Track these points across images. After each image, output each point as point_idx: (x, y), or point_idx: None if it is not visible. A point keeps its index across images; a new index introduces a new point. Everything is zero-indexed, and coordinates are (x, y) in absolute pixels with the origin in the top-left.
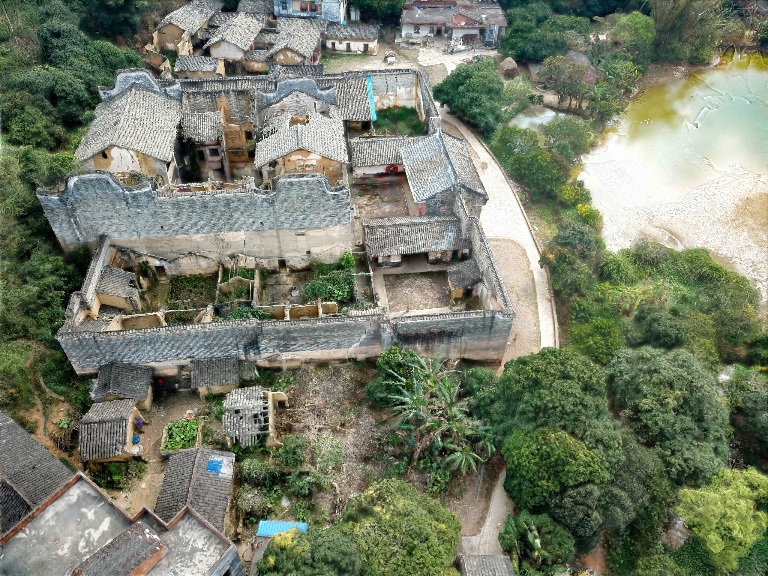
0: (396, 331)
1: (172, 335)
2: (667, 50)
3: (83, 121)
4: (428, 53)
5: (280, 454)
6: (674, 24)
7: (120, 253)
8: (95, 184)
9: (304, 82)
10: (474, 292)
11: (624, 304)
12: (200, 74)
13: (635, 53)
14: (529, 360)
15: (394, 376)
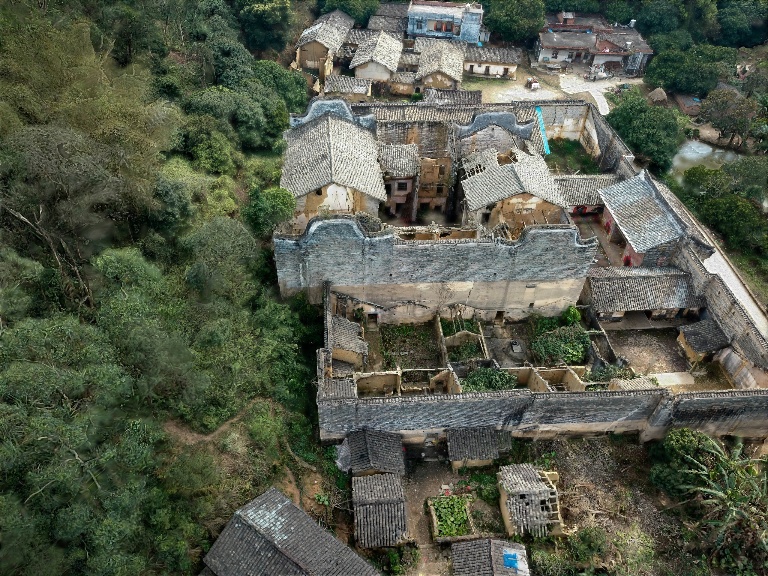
0: (676, 407)
1: (438, 404)
2: None
3: (276, 150)
4: (569, 79)
5: (566, 545)
6: None
7: (340, 300)
8: (338, 229)
9: (503, 116)
10: (716, 356)
11: None
12: (350, 96)
13: None
14: None
15: (694, 463)
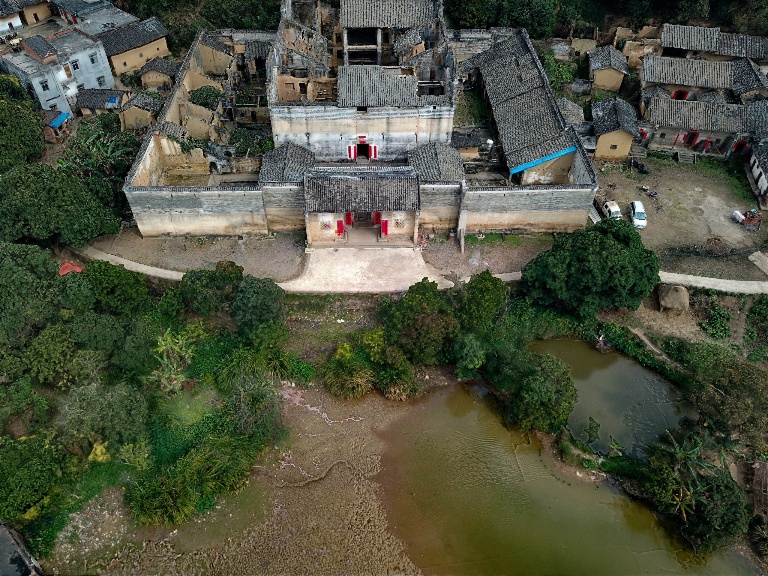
0: None
1: None
2: None
3: None
4: None
5: None
6: None
7: None
8: None
9: None
10: None
11: None
12: None
13: None
14: None
15: None
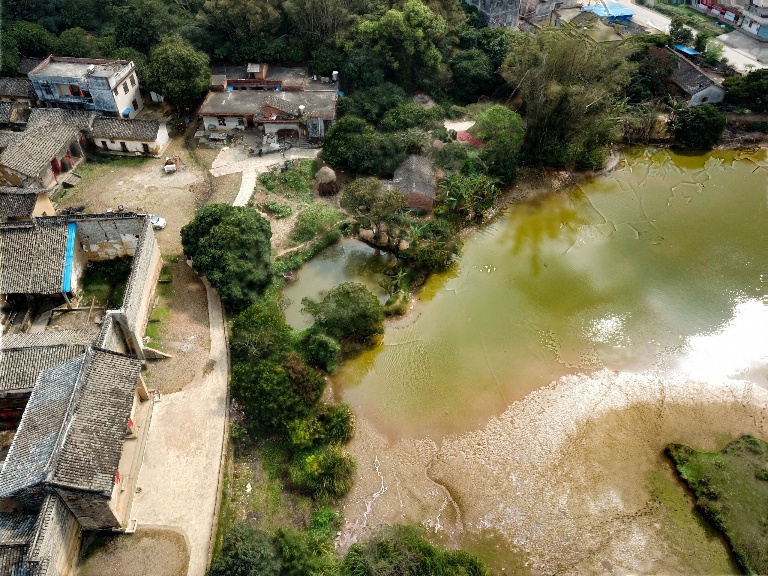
0: None
1: None
2: (544, 151)
3: None
4: (229, 154)
5: None
6: (552, 119)
7: None
8: None
9: None
10: None
11: None
12: None
13: (491, 163)
14: None
15: None
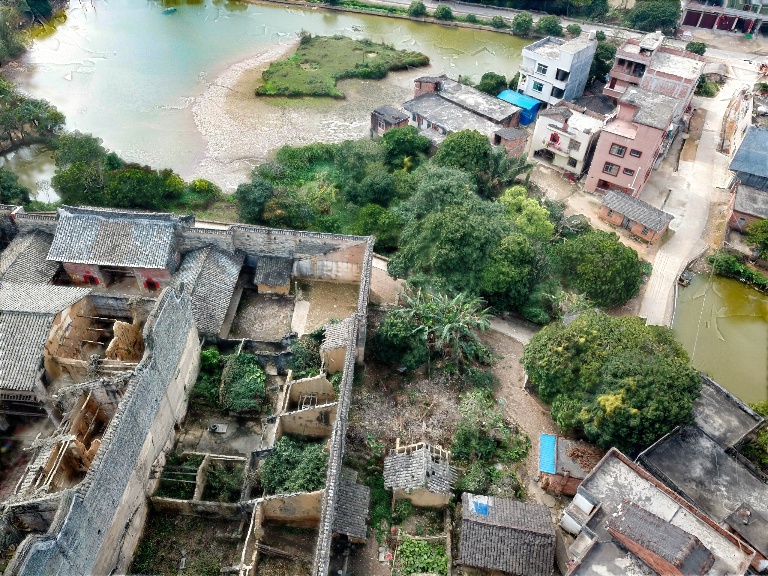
0: None
1: None
2: None
3: None
4: None
5: (456, 459)
6: None
7: None
8: None
9: None
10: (292, 275)
11: (328, 203)
12: None
13: None
14: (426, 242)
15: None
